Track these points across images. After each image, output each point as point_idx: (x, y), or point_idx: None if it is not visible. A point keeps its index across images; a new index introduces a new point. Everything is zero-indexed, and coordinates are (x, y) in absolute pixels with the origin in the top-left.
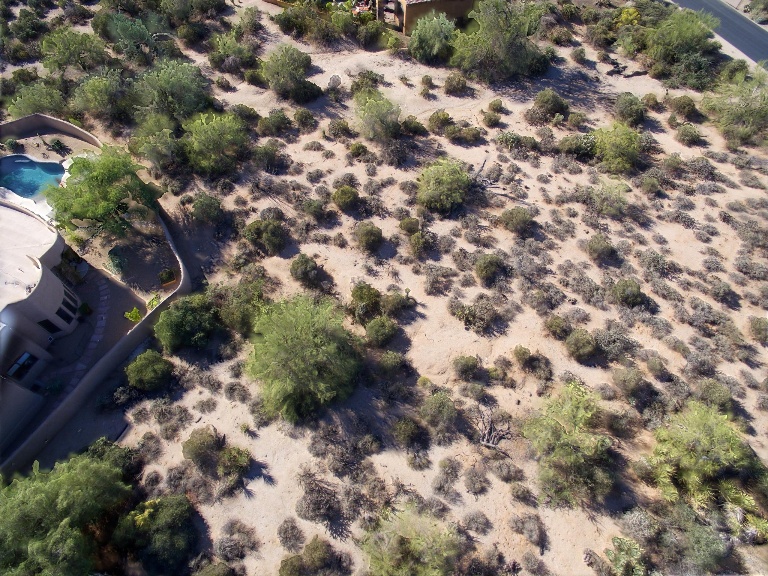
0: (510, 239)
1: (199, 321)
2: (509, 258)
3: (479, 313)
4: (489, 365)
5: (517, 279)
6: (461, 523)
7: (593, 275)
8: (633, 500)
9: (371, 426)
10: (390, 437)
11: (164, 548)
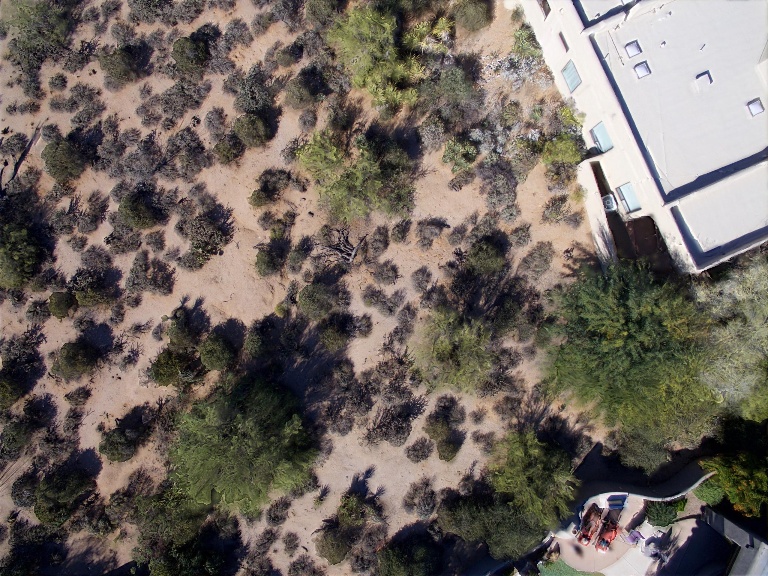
0: (96, 176)
1: (190, 571)
2: (126, 184)
3: (204, 238)
4: (267, 237)
5: (159, 181)
6: (421, 295)
7: (161, 86)
8: (412, 130)
9: (325, 371)
10: (338, 353)
11: (424, 568)
